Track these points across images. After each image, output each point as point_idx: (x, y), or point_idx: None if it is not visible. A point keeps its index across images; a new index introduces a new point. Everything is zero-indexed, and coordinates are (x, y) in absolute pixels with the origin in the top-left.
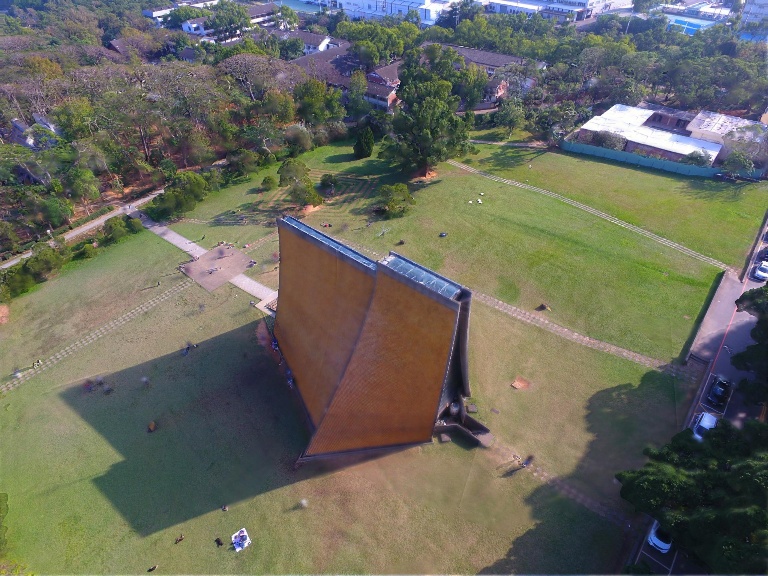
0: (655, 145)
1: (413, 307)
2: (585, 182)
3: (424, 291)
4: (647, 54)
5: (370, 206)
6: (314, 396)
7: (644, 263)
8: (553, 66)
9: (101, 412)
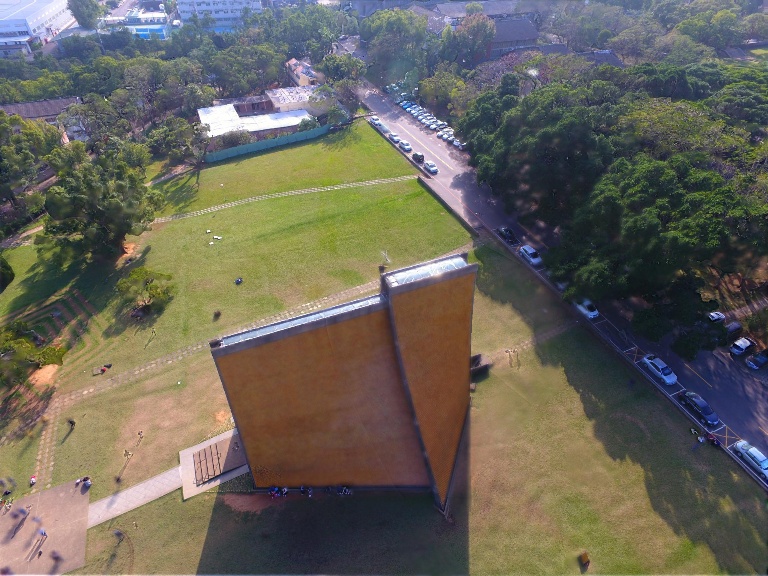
0: (270, 127)
1: (436, 300)
2: (266, 176)
3: (445, 277)
4: (181, 60)
5: (119, 316)
6: (386, 468)
7: (382, 201)
8: (111, 95)
9: None
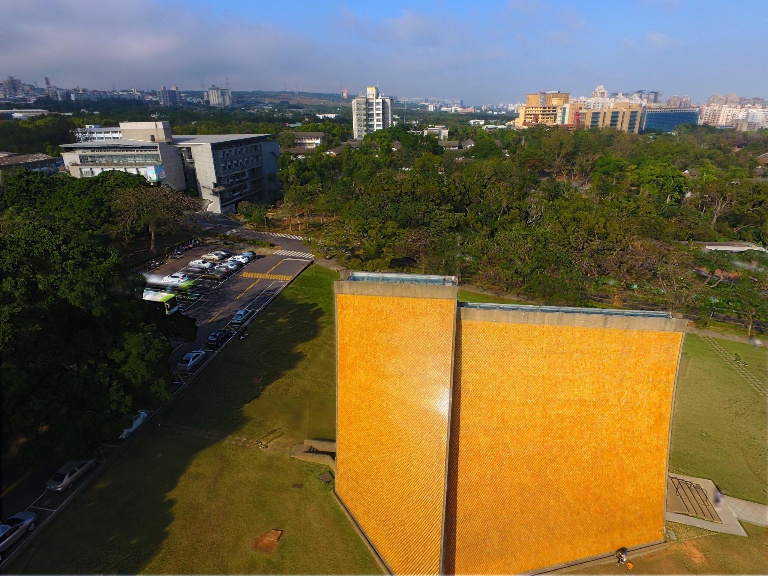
0: None
1: None
2: None
3: None
4: None
5: None
6: None
7: None
8: None
9: None
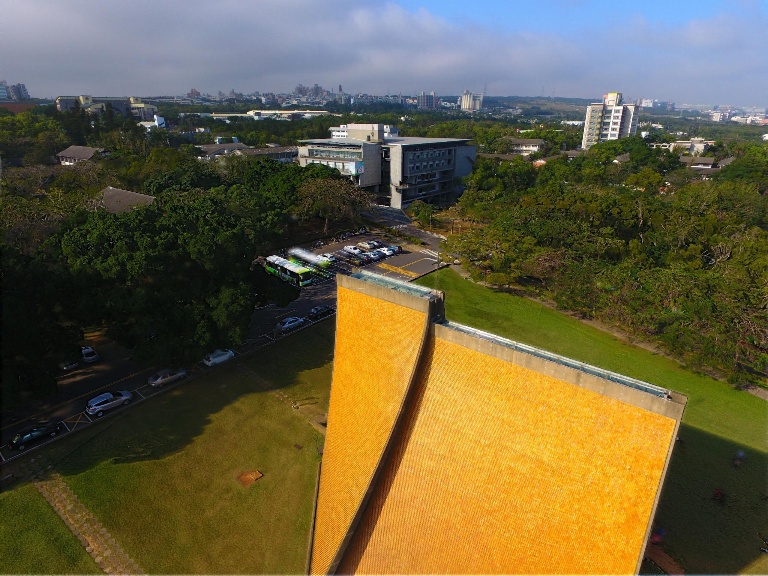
0: None
1: None
2: None
3: None
4: None
5: None
6: None
7: None
8: None
9: (764, 460)
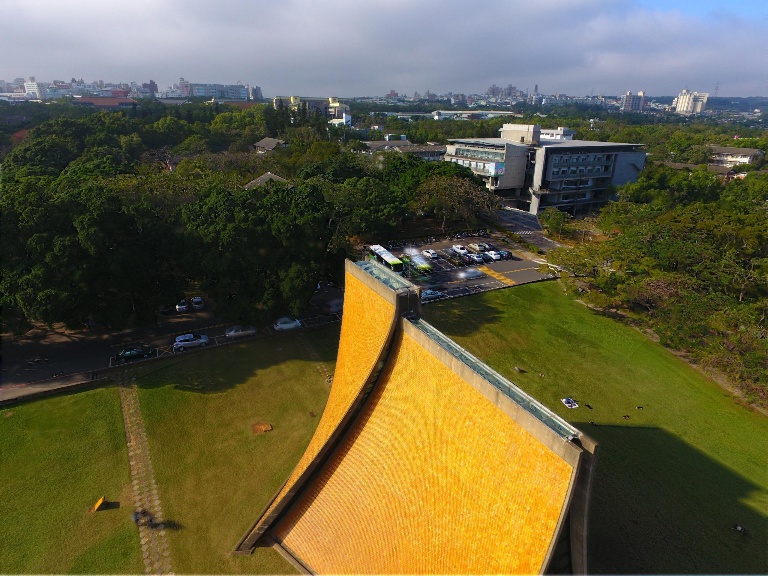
0: None
1: None
2: None
3: None
4: None
5: None
6: None
7: None
8: None
9: None
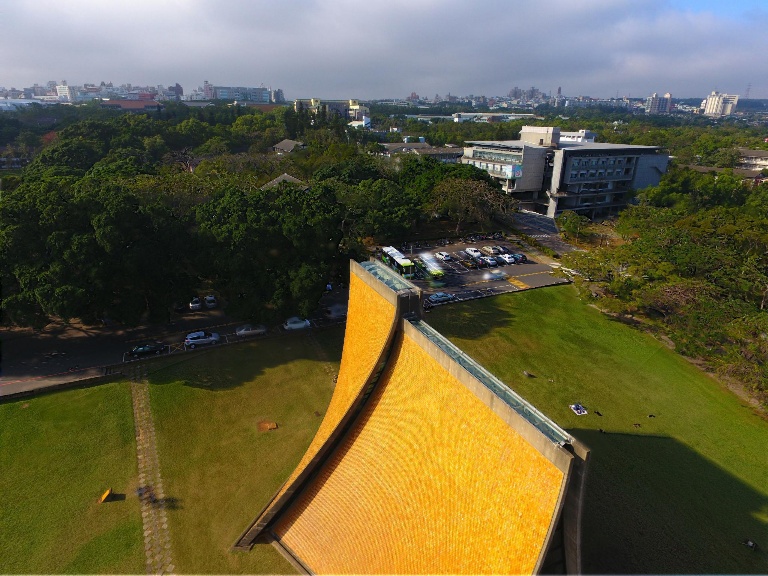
0: None
1: None
2: None
3: None
4: None
5: None
6: None
7: None
8: None
9: None
